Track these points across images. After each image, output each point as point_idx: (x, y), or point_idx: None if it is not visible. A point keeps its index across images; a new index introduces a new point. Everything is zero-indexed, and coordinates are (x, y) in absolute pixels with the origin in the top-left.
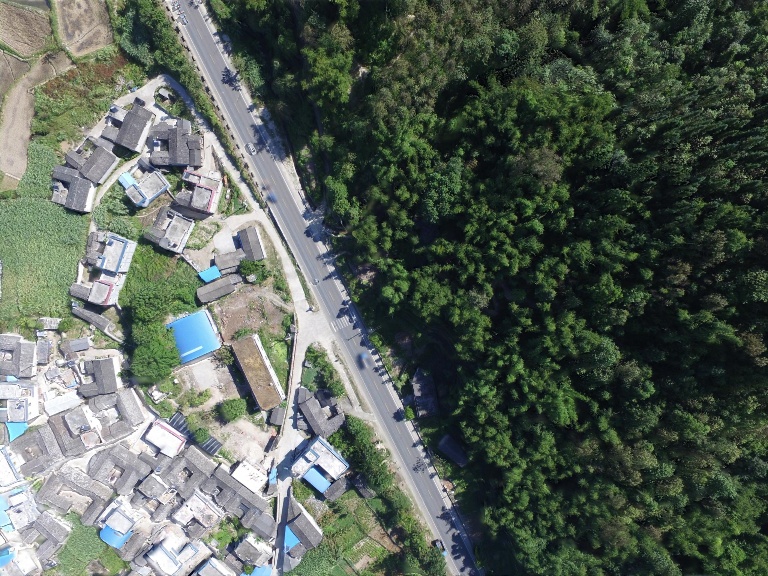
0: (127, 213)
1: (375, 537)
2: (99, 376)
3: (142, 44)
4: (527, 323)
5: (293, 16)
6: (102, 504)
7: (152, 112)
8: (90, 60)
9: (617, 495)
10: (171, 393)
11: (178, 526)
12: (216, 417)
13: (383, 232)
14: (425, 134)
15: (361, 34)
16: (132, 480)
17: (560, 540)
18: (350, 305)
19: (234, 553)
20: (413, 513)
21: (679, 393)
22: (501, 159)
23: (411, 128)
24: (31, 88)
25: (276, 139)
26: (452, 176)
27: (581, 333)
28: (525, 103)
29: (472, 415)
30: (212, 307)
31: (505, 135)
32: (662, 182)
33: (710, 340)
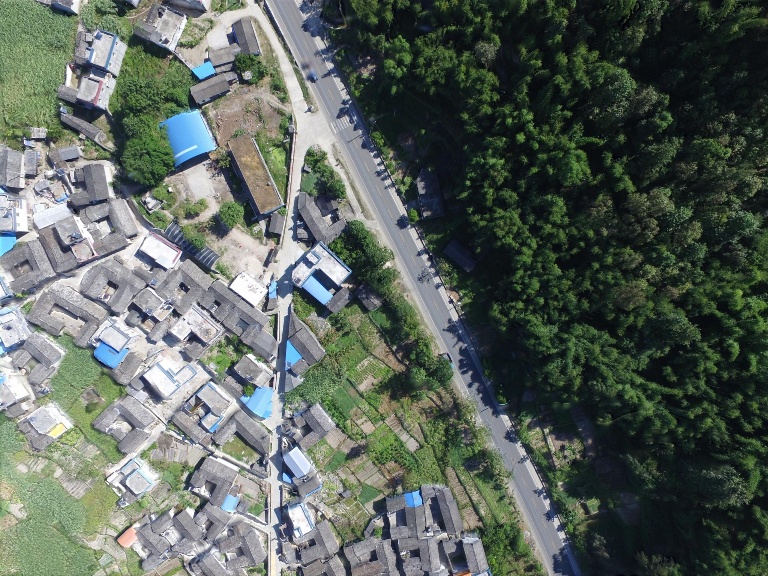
0: (116, 12)
1: (379, 355)
2: (90, 182)
3: None
4: (537, 64)
5: None
6: (96, 324)
7: None
8: None
9: (632, 256)
10: (165, 202)
11: (175, 350)
12: (213, 229)
13: (384, 2)
14: None
15: None
16: (126, 296)
17: (573, 318)
18: (350, 105)
19: (234, 375)
20: (419, 323)
21: (698, 119)
22: None
23: None
24: None
25: None
26: None
27: (594, 64)
28: None
29: (479, 195)
30: (207, 109)
31: None
32: None
33: (732, 37)
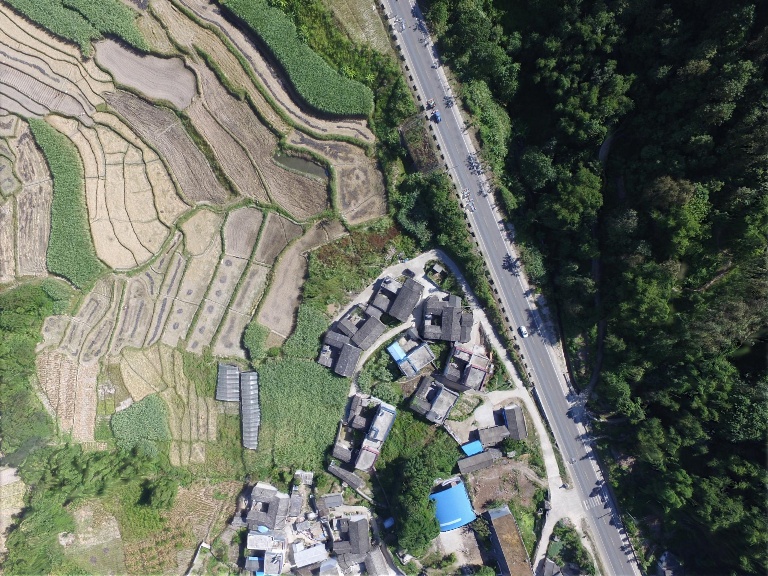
0: (390, 380)
1: None
2: (354, 537)
3: (422, 222)
4: None
5: (600, 227)
6: None
7: None
8: (363, 229)
9: None
10: (419, 556)
11: None
12: None
13: (670, 437)
14: (728, 354)
15: None
16: None
17: None
18: (603, 485)
19: None
20: None
21: None
22: None
23: (725, 354)
24: (304, 252)
25: (548, 324)
26: (767, 407)
27: None
28: None
29: None
30: (467, 477)
31: None
32: None
33: None
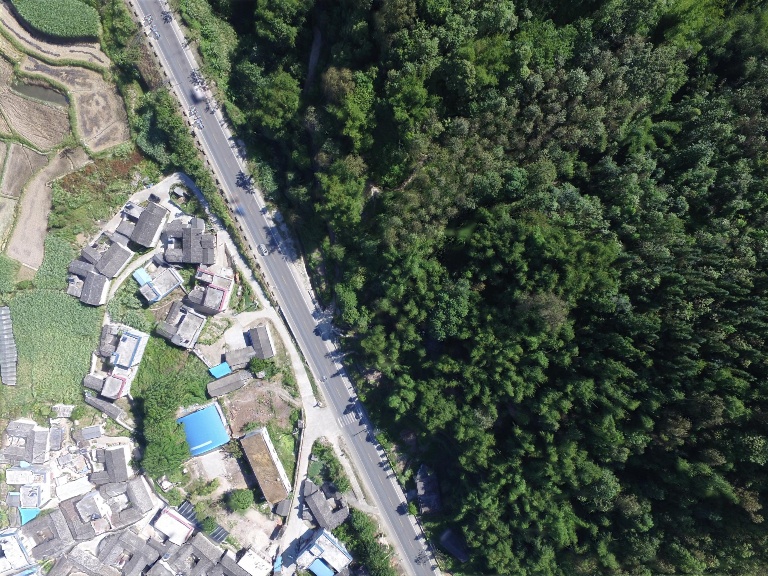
0: (140, 307)
1: None
2: (110, 466)
3: (158, 144)
4: (530, 450)
5: (307, 133)
6: None
7: (167, 208)
8: (107, 156)
9: None
10: (180, 482)
11: None
12: (223, 506)
13: (391, 343)
14: (434, 253)
15: (374, 159)
16: (140, 565)
17: None
18: (357, 402)
19: None
20: None
21: (677, 529)
22: (508, 290)
23: (421, 251)
24: (49, 182)
25: (288, 241)
26: (460, 301)
27: (583, 465)
28: (533, 240)
29: (474, 522)
30: (222, 400)
31: (513, 266)
32: (665, 335)
33: (708, 490)
